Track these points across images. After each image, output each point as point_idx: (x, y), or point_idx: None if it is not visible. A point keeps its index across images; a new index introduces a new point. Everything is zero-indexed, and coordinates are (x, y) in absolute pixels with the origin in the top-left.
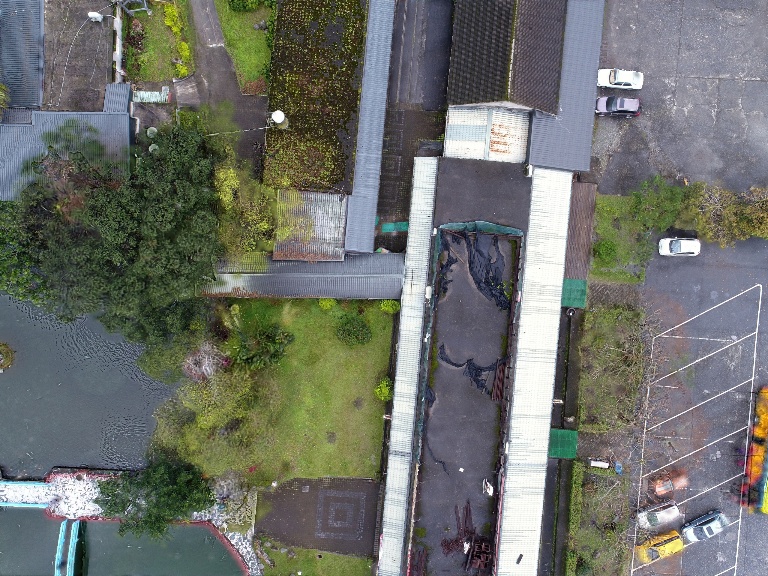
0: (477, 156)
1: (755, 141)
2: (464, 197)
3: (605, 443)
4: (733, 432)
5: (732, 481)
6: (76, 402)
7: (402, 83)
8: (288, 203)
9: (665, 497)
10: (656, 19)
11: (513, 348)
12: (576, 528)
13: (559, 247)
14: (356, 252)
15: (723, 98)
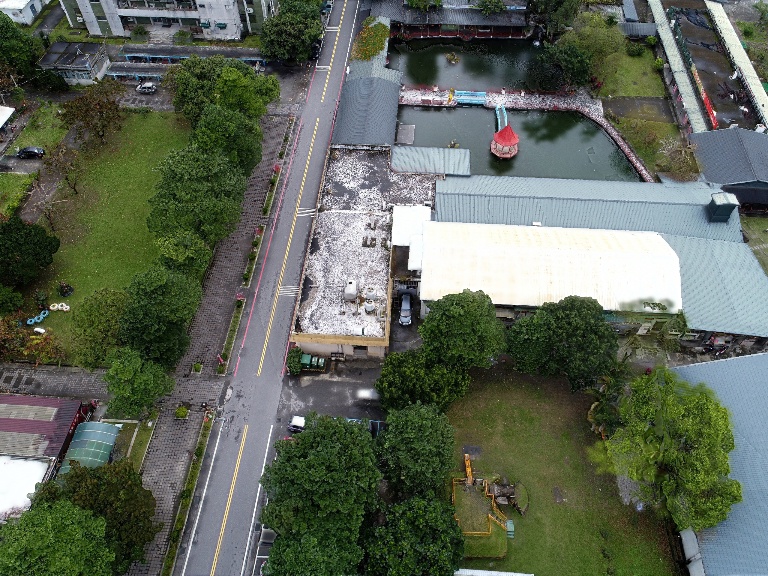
0: None
1: None
2: (676, 4)
3: None
4: None
5: None
6: (492, 75)
7: None
8: (594, 7)
9: None
10: None
11: None
12: None
13: (726, 20)
14: None
15: None
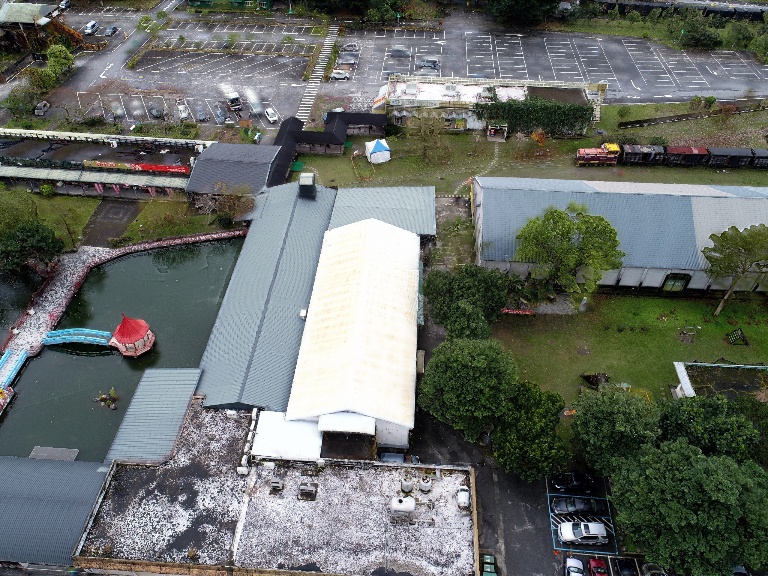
0: None
1: None
2: None
3: (127, 130)
4: (142, 99)
5: None
6: None
7: None
8: None
9: (160, 112)
10: None
11: None
12: (162, 135)
13: None
14: None
15: None
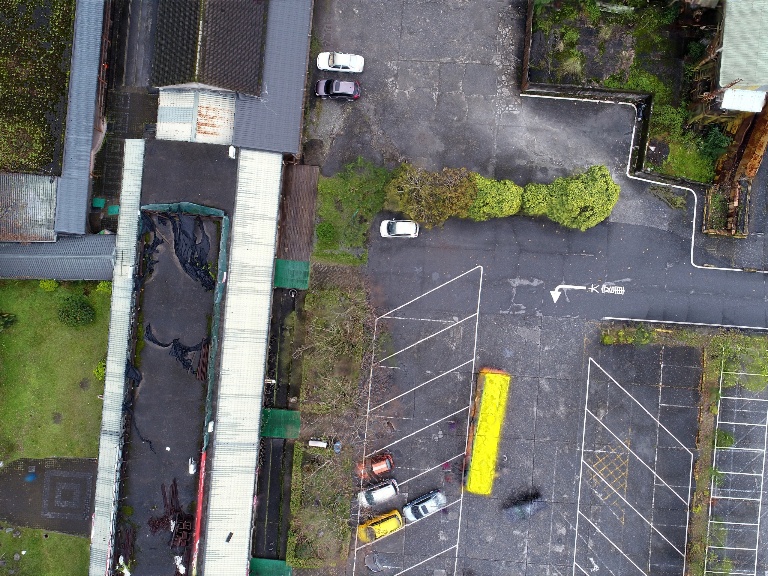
0: (185, 138)
1: (476, 124)
2: (170, 178)
3: (328, 423)
4: (455, 412)
5: (454, 461)
6: None
7: (128, 67)
8: None
9: (383, 476)
10: (378, 3)
11: (218, 328)
12: (296, 507)
13: (269, 228)
14: (70, 233)
15: (444, 81)
